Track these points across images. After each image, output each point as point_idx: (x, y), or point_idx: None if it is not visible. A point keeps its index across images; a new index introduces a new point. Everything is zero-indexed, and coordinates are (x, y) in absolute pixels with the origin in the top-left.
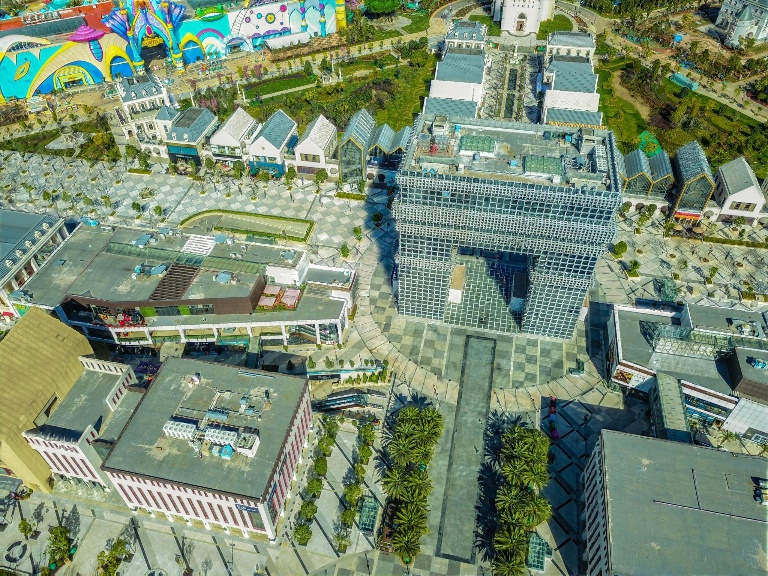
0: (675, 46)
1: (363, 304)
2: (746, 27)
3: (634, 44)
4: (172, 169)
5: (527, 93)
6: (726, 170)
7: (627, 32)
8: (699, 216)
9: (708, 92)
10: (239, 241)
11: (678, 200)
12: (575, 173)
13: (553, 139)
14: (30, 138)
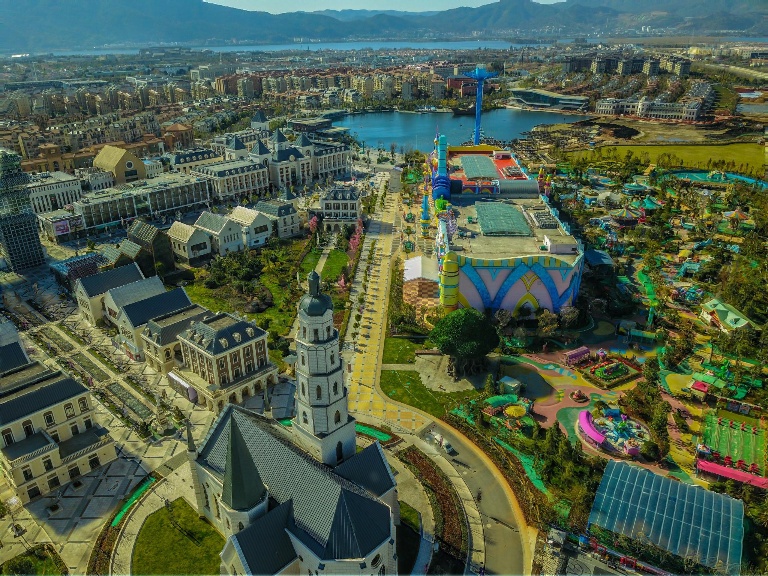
0: None
1: (52, 245)
2: None
3: None
4: None
5: None
6: None
7: None
8: None
9: None
10: (120, 197)
11: None
12: None
13: None
14: (372, 199)
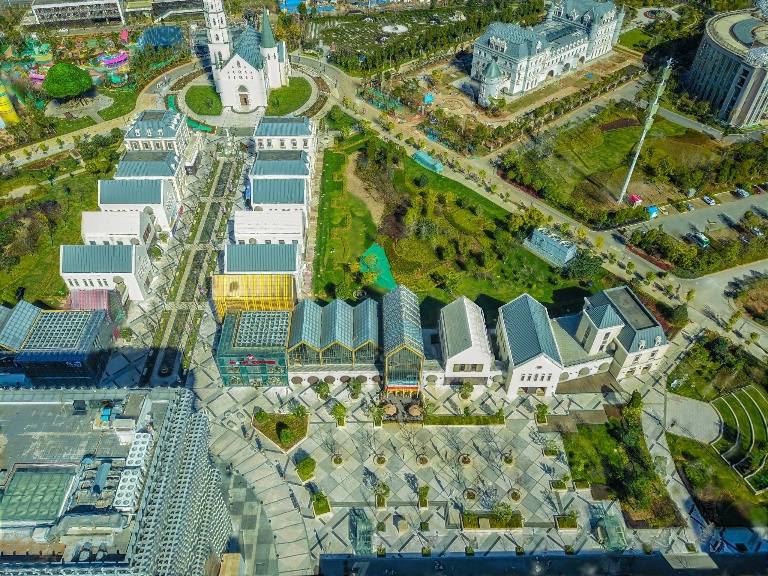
0: (424, 111)
1: None
2: (495, 84)
3: (379, 111)
4: None
5: (237, 199)
6: (447, 315)
7: (374, 95)
8: (417, 388)
9: (455, 173)
10: None
11: (385, 373)
12: (70, 522)
13: (89, 411)
14: None
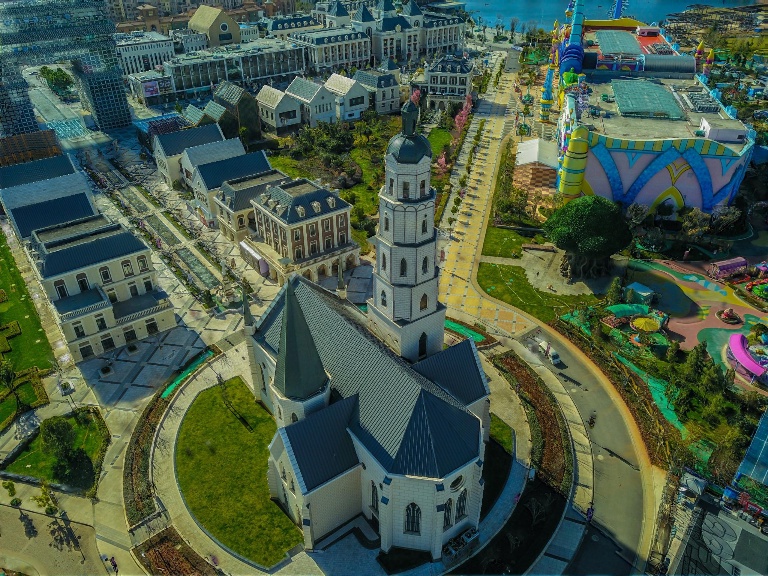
0: None
1: (141, 107)
2: None
3: None
4: None
5: (151, 254)
6: None
7: None
8: None
9: None
10: None
11: None
12: None
13: None
14: None
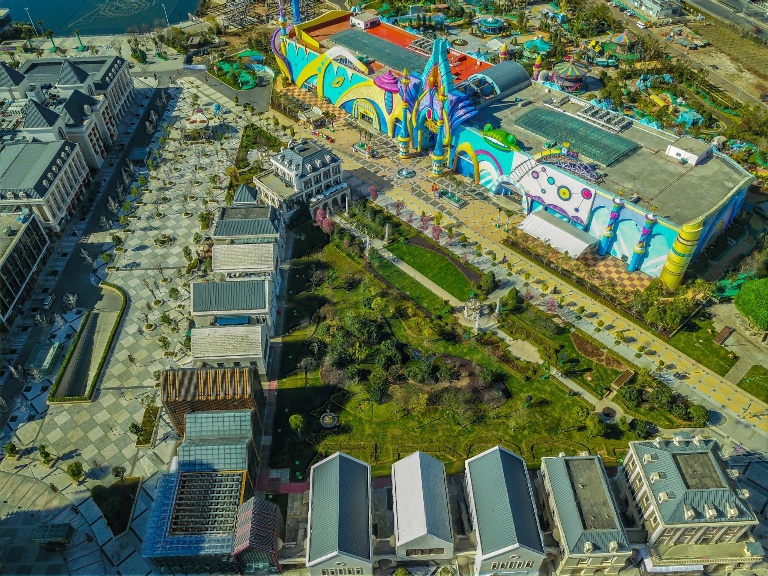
0: None
1: None
2: None
3: None
4: (193, 240)
5: None
6: None
7: None
8: None
9: None
10: None
11: None
12: None
13: None
14: (264, 136)
